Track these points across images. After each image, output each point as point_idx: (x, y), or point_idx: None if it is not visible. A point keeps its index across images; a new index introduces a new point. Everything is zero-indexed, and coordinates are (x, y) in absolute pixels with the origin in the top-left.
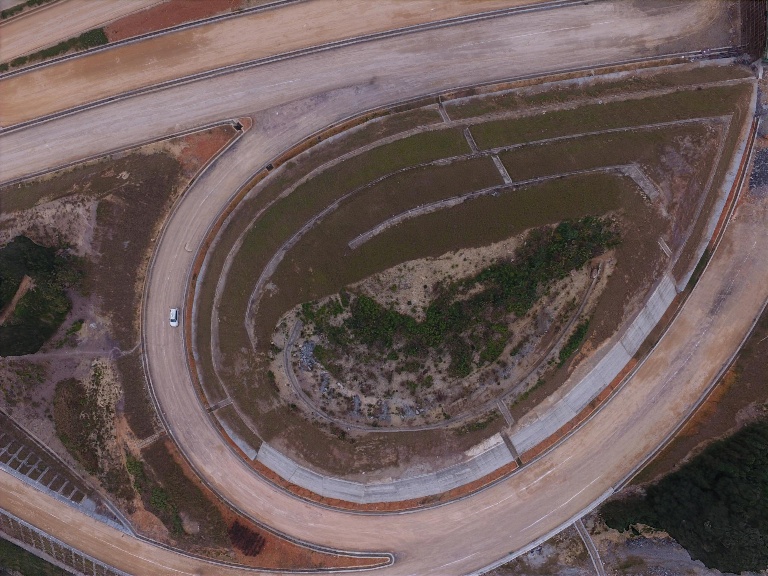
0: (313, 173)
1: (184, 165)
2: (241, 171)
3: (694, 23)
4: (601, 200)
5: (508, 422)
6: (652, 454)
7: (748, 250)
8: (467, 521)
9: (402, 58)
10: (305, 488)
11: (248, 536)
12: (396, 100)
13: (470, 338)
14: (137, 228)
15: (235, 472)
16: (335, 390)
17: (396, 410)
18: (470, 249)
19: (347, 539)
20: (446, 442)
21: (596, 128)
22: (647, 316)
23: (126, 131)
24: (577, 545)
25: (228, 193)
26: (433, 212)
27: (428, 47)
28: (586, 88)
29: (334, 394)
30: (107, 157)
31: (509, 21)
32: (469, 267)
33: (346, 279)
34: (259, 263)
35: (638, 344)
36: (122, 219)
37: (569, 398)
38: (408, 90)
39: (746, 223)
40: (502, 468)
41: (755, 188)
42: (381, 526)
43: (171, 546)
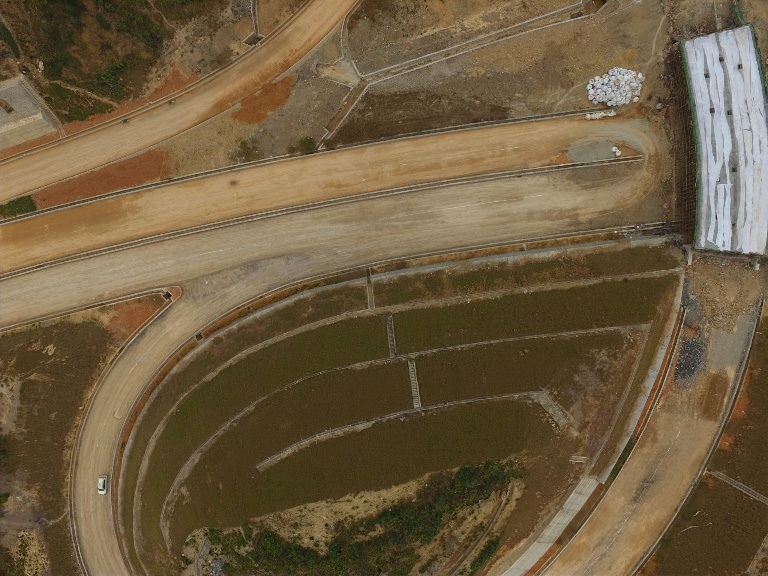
0: (236, 358)
1: (113, 334)
2: (170, 339)
3: (628, 197)
4: (505, 438)
5: None
6: None
7: (672, 440)
8: None
9: (333, 229)
10: None
11: None
12: (326, 271)
13: (376, 564)
14: (64, 399)
15: None
16: None
17: None
18: (370, 492)
19: None
20: None
21: (514, 333)
22: (566, 512)
23: (55, 298)
24: None
25: (157, 361)
26: (341, 436)
27: (359, 218)
28: (515, 268)
29: None
30: (36, 324)
31: (441, 193)
32: (370, 507)
33: (250, 511)
34: (176, 462)
35: (559, 532)
36: (48, 394)
37: None
38: (339, 261)
39: (670, 413)
40: None
41: (680, 379)
42: None
43: None
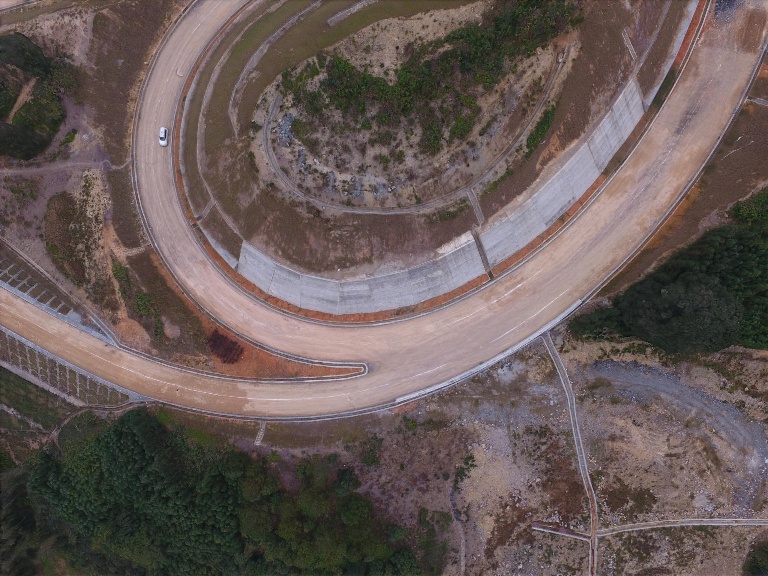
0: None
1: None
2: (232, 1)
3: None
4: None
5: (478, 220)
6: (619, 267)
7: (713, 72)
8: (439, 333)
9: None
10: (284, 300)
11: (227, 344)
12: None
13: (440, 109)
14: (131, 49)
15: (217, 285)
16: (311, 166)
17: (369, 187)
18: (440, 10)
19: (323, 350)
20: (418, 235)
21: None
22: (614, 124)
23: None
24: (546, 362)
25: (219, 22)
26: None
27: None
28: None
29: (310, 170)
30: None
31: None
32: (439, 29)
33: (323, 44)
34: (244, 58)
35: (606, 159)
36: (117, 36)
37: (538, 200)
38: None
39: (711, 47)
40: (474, 280)
41: (720, 13)
42: (356, 338)
43: (152, 356)
